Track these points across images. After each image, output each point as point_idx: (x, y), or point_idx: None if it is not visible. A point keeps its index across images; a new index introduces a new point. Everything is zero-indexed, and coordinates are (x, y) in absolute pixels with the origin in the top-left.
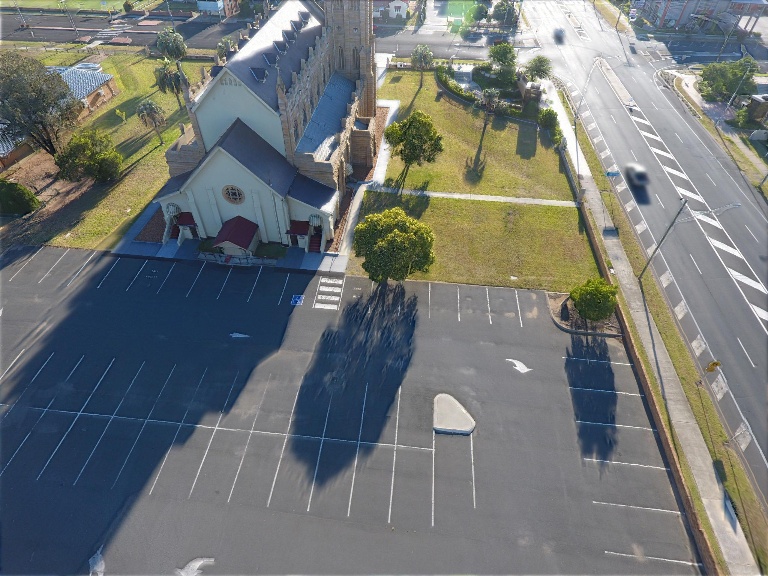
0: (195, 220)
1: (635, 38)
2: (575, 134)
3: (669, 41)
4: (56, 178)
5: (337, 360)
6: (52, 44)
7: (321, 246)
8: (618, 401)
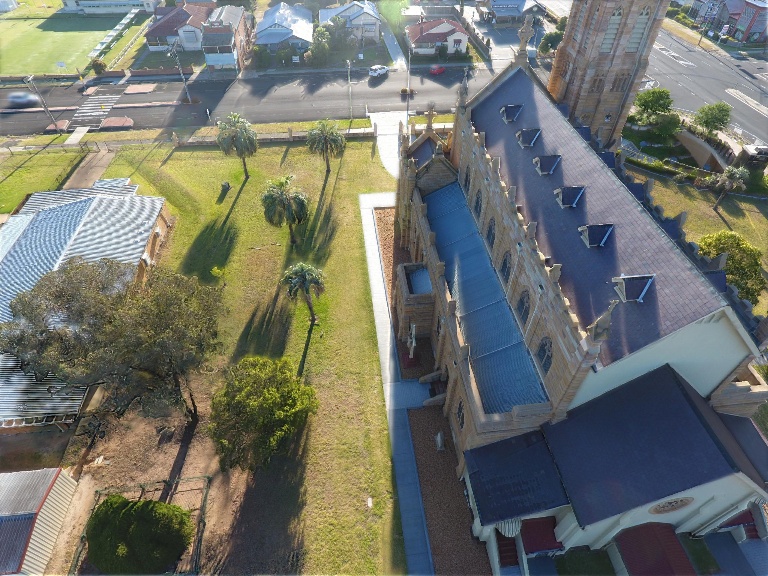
0: (561, 539)
1: (732, 58)
2: None
3: (767, 58)
4: (221, 470)
5: None
6: (12, 139)
7: (767, 531)
8: None
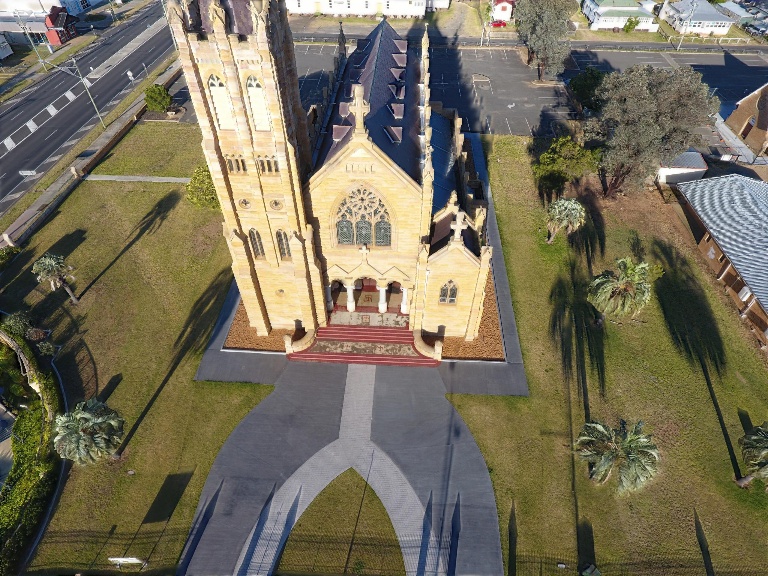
0: None
1: None
2: None
3: None
4: None
5: (314, 97)
6: None
7: None
8: (181, 88)
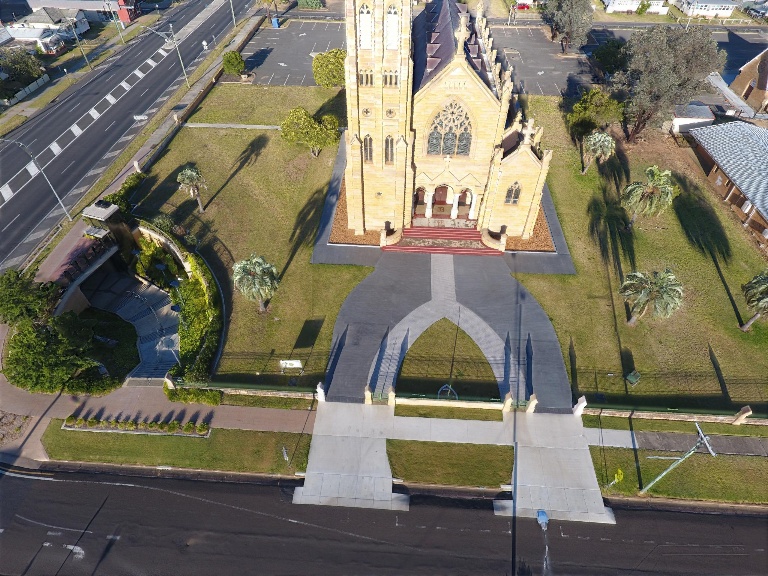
0: None
1: None
2: (99, 196)
3: None
4: None
5: None
6: None
7: None
8: None
